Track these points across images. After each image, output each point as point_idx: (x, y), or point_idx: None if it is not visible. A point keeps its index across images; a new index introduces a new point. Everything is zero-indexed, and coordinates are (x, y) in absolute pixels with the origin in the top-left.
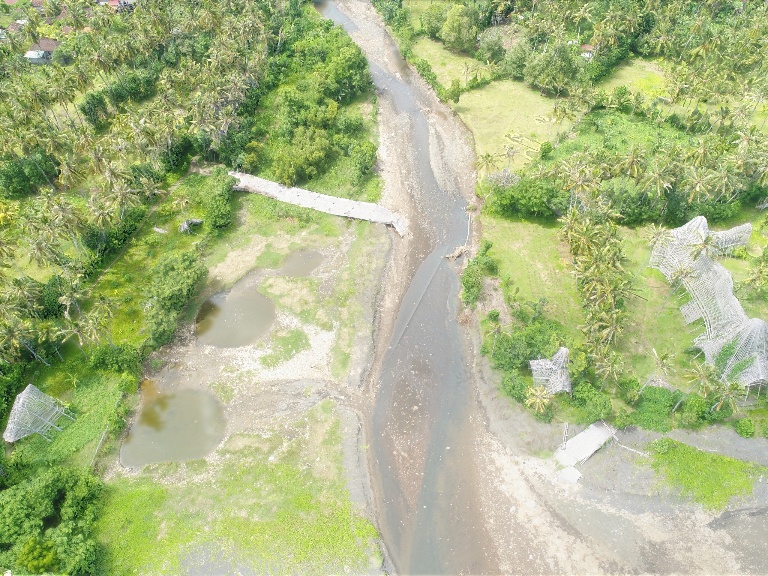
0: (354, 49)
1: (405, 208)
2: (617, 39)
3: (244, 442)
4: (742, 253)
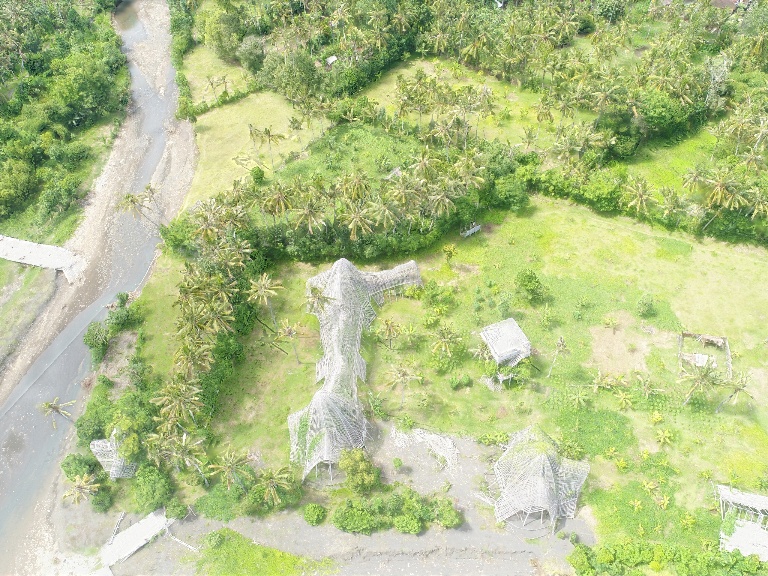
0: (86, 68)
1: (91, 249)
2: (385, 40)
3: None
4: (412, 293)
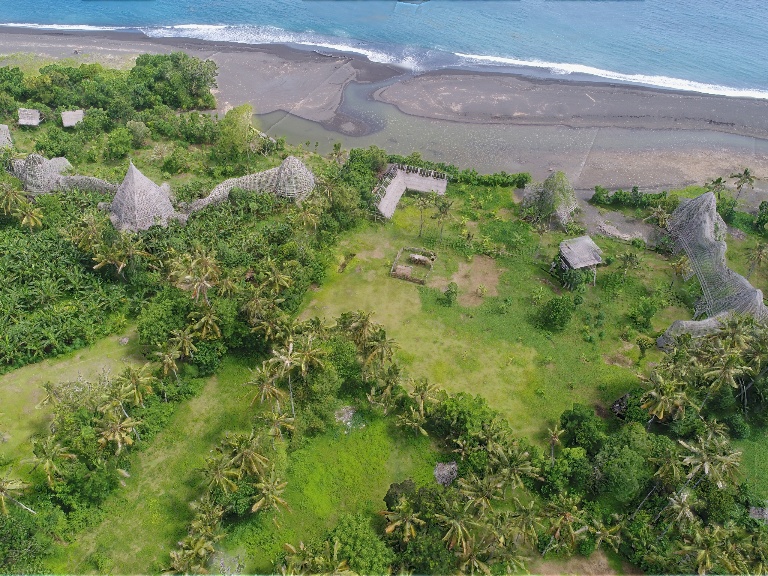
0: None
1: None
2: None
3: None
4: None
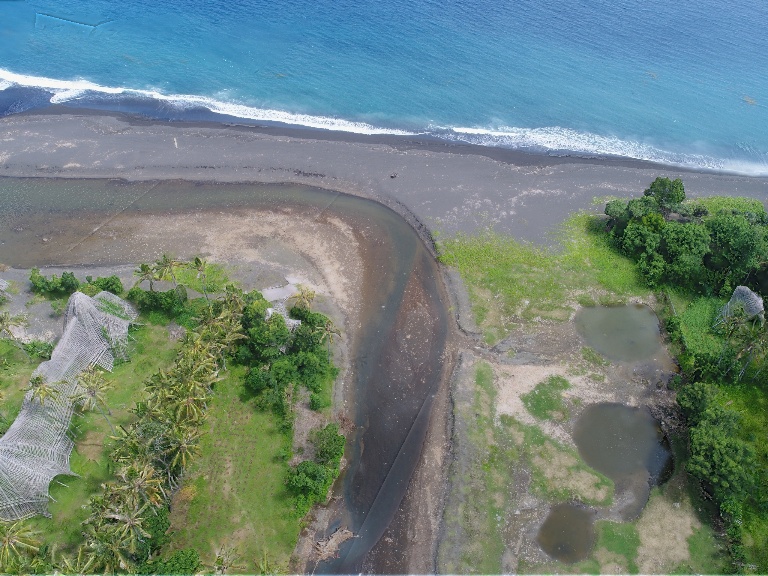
0: None
1: None
2: None
3: (554, 314)
4: None
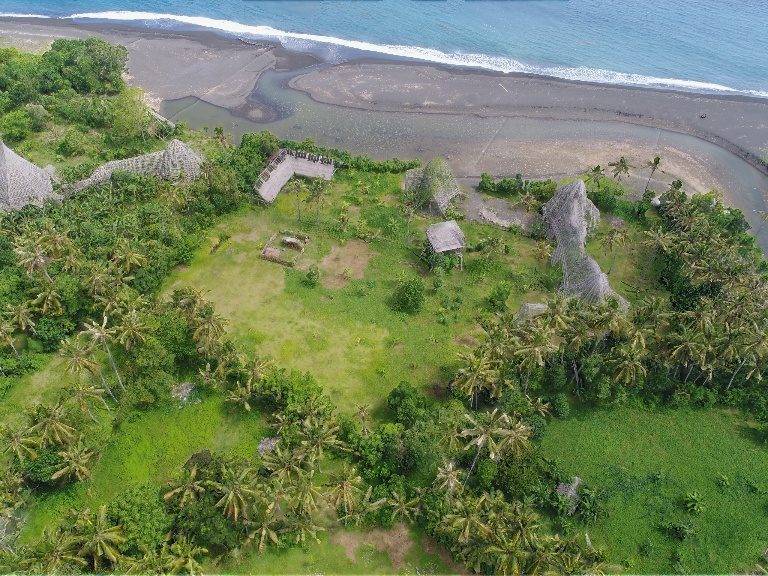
0: None
1: None
2: None
3: None
4: None
